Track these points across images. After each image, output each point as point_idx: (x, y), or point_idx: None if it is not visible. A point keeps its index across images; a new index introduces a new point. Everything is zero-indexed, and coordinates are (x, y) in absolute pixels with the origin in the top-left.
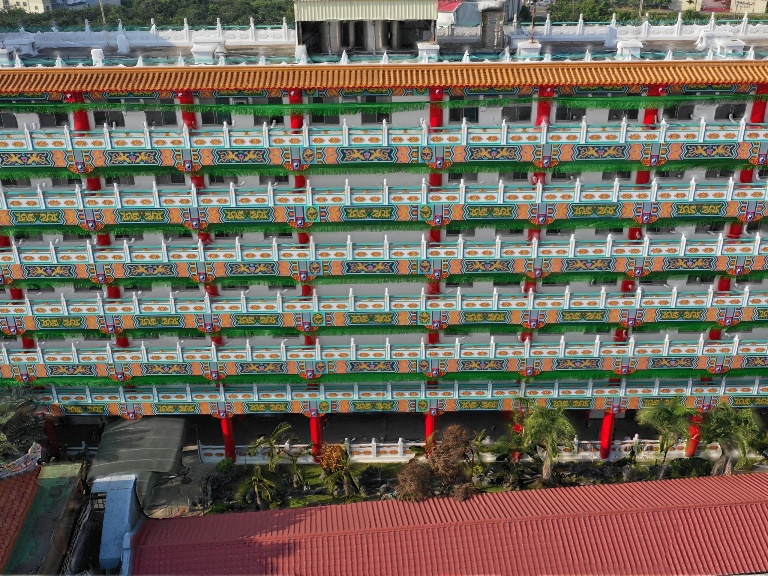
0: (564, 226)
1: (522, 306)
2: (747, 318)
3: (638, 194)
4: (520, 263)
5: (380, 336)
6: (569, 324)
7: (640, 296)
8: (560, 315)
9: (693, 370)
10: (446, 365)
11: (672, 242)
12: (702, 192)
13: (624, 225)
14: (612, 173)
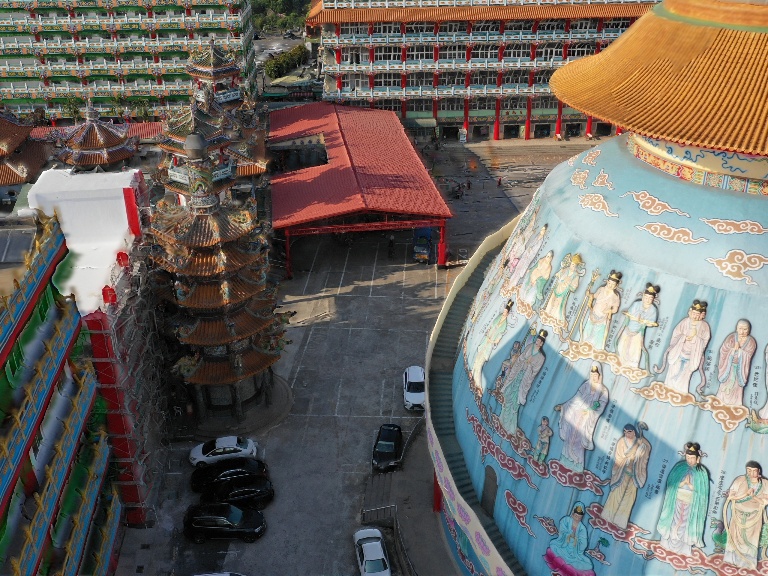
0: (87, 36)
1: (75, 68)
2: (164, 73)
3: (107, 21)
4: (69, 49)
5: (23, 82)
6: (95, 76)
7: (120, 63)
8: (91, 72)
9: (150, 97)
10: (51, 95)
11: (126, 40)
12: (130, 20)
13: (111, 35)
14: (100, 14)
